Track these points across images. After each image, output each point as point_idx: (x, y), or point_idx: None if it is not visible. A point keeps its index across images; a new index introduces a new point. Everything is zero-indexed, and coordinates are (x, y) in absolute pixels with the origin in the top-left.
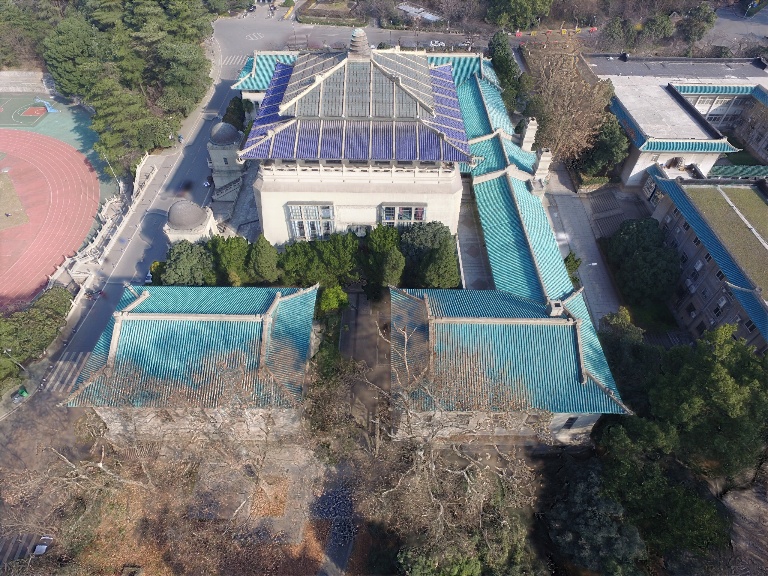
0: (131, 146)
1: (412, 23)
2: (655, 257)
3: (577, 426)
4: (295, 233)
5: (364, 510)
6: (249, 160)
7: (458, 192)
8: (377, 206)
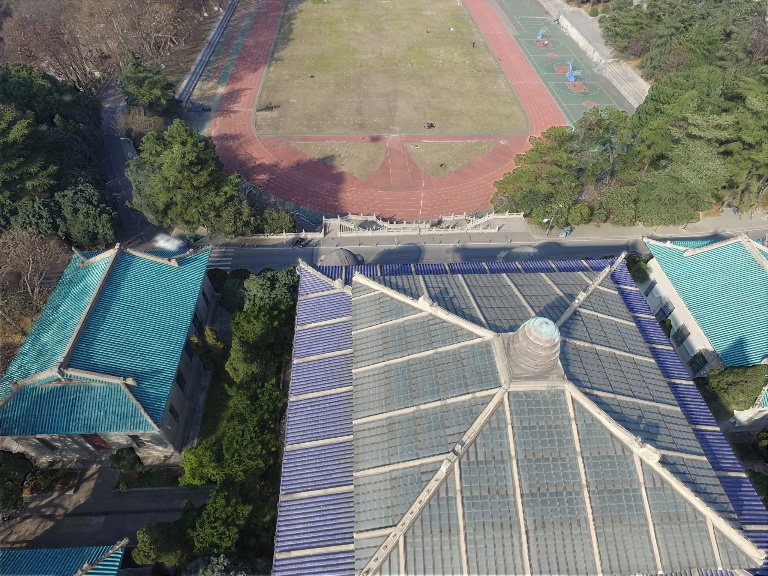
0: None
1: None
2: None
3: None
4: None
5: None
6: None
7: None
8: None
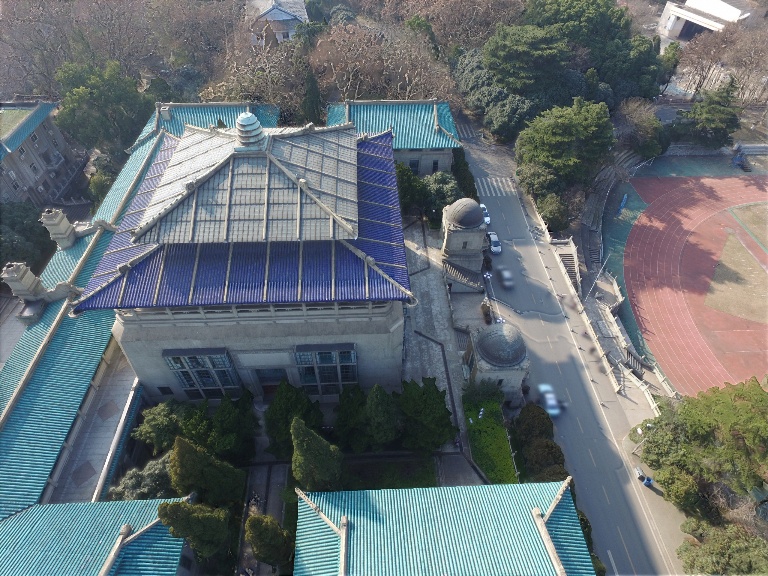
0: None
1: None
2: None
3: None
4: None
5: None
6: (469, 379)
7: None
8: None
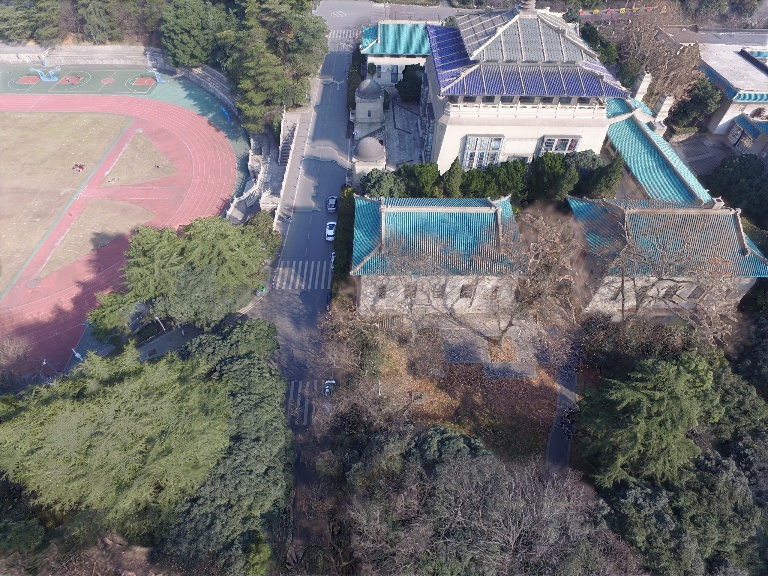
0: (272, 104)
1: (482, 3)
2: (760, 182)
3: (731, 297)
4: (465, 164)
5: (596, 344)
6: (383, 115)
7: (607, 126)
8: (539, 138)
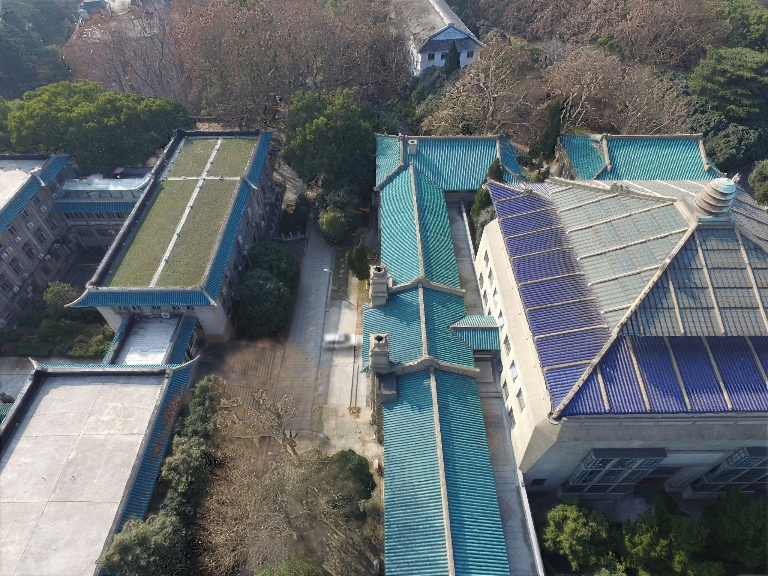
0: None
1: None
2: None
3: None
4: None
5: None
6: None
7: None
8: None
